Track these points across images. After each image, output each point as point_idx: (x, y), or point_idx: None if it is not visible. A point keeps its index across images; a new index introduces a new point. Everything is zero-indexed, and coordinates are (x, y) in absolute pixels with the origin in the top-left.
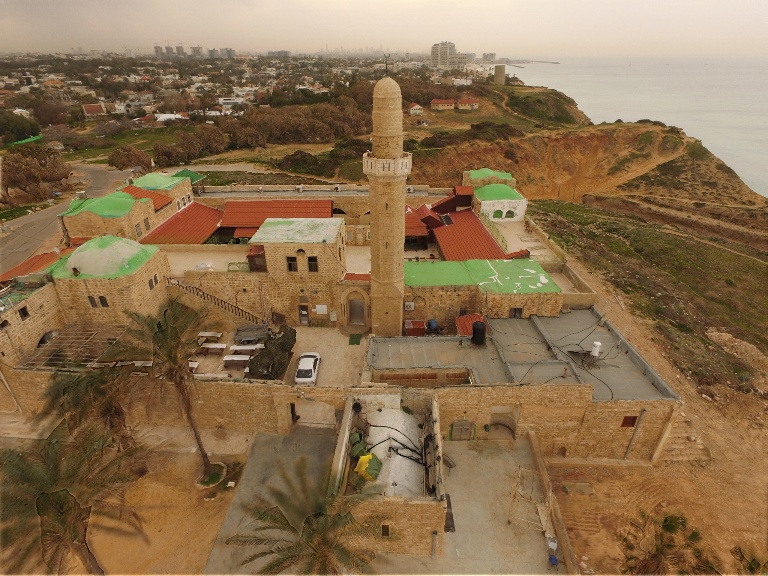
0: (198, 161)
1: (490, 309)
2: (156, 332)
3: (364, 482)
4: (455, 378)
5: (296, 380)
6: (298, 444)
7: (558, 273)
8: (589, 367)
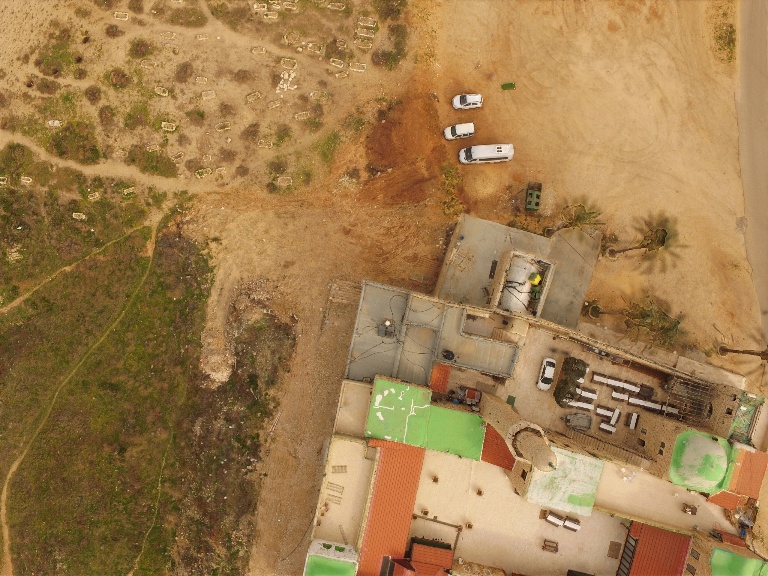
0: None
1: None
2: None
3: None
4: None
5: None
6: (555, 320)
7: (339, 432)
8: None
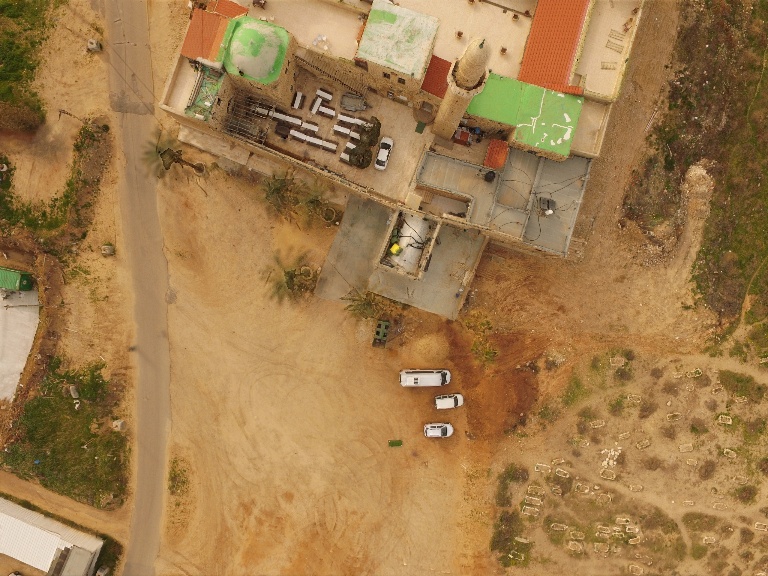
0: None
1: (515, 146)
2: (309, 202)
3: (393, 254)
4: (463, 198)
5: (375, 166)
6: (370, 209)
7: (603, 105)
8: (541, 215)
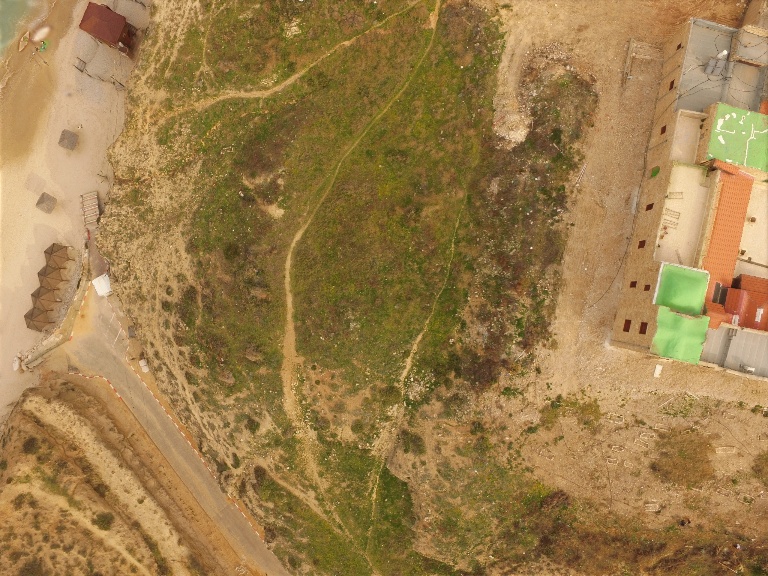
0: None
1: None
2: None
3: None
4: None
5: None
6: None
7: None
8: None
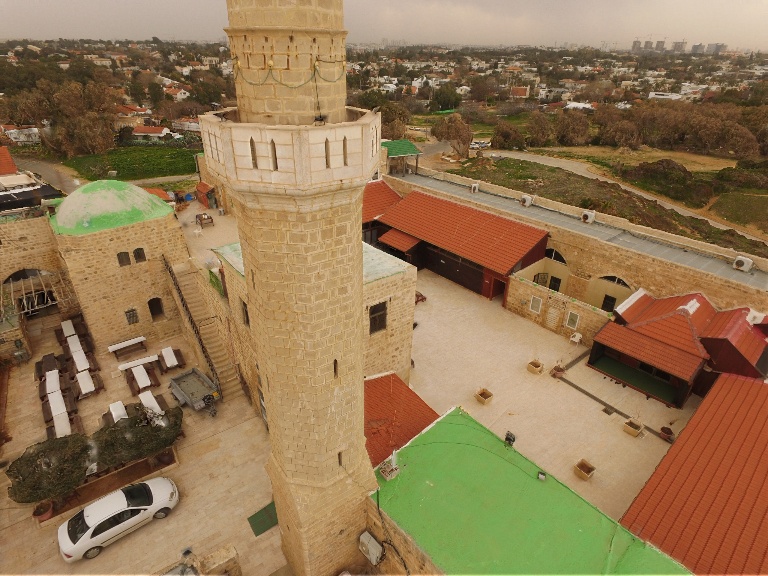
0: (536, 149)
1: None
2: None
3: None
4: None
5: (60, 526)
6: None
7: None
8: None
